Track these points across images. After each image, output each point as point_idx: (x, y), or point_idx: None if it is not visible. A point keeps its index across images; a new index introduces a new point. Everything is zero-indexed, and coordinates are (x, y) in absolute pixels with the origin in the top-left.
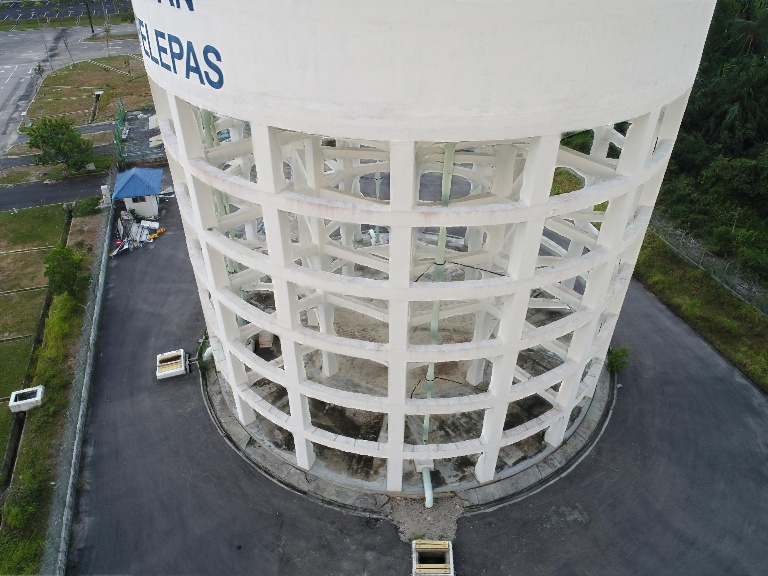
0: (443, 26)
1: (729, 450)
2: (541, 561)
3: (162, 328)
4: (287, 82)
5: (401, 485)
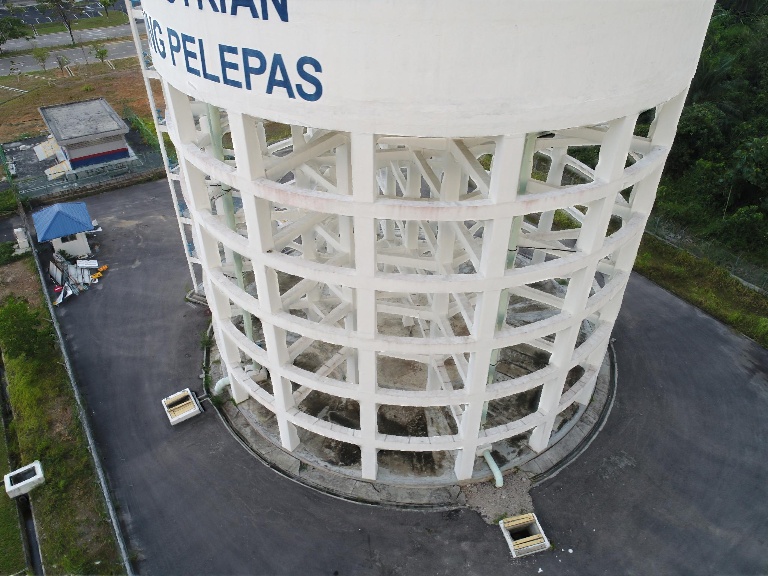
0: (562, 20)
1: (718, 376)
2: (614, 509)
3: (152, 371)
4: (402, 87)
5: (472, 472)
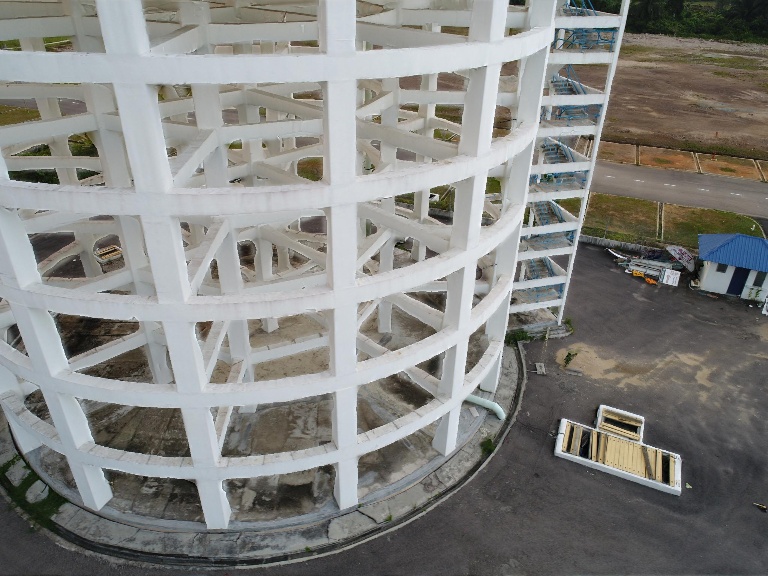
0: None
1: None
2: None
3: None
4: None
5: None
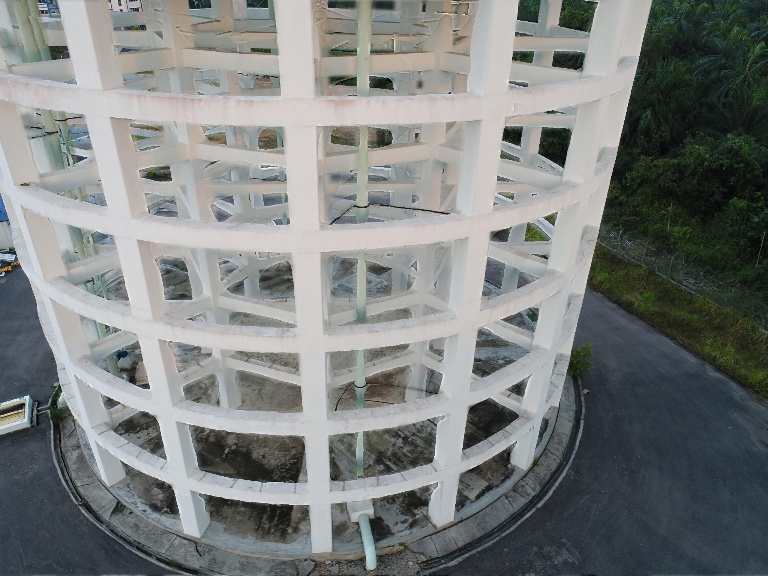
0: None
1: (724, 453)
2: None
3: (4, 373)
4: None
5: (331, 542)
